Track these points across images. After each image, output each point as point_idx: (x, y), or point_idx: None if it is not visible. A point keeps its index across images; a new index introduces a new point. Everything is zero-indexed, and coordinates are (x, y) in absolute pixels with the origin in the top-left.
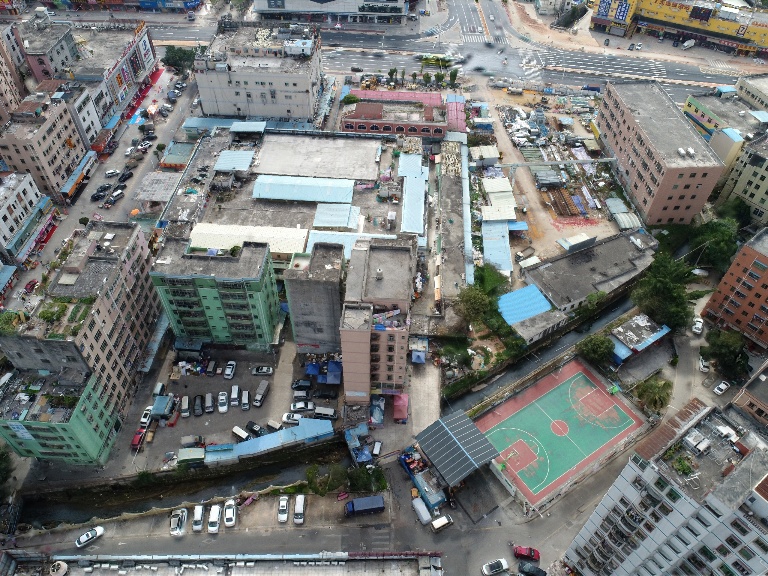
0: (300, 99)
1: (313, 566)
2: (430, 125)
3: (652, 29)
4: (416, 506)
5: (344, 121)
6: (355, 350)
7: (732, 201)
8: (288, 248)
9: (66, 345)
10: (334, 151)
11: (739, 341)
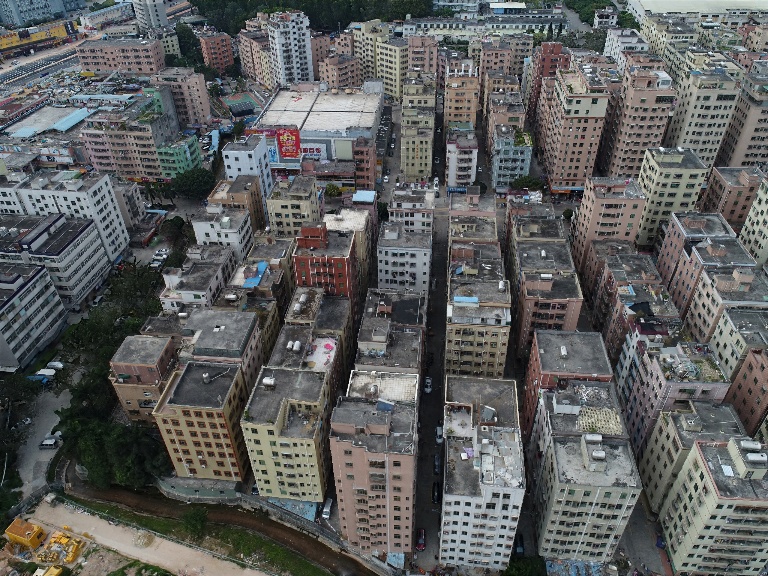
0: None
1: (274, 101)
2: (42, 99)
3: (6, 55)
4: None
5: (8, 118)
6: (202, 88)
7: (165, 59)
8: None
9: (165, 117)
10: None
11: (233, 64)
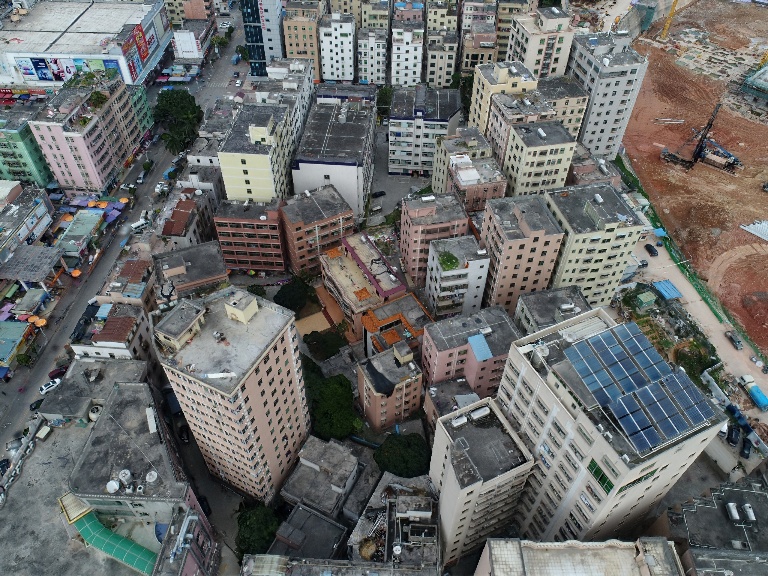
0: None
1: None
2: None
3: None
4: None
5: None
6: None
7: None
8: None
9: None
10: None
11: None
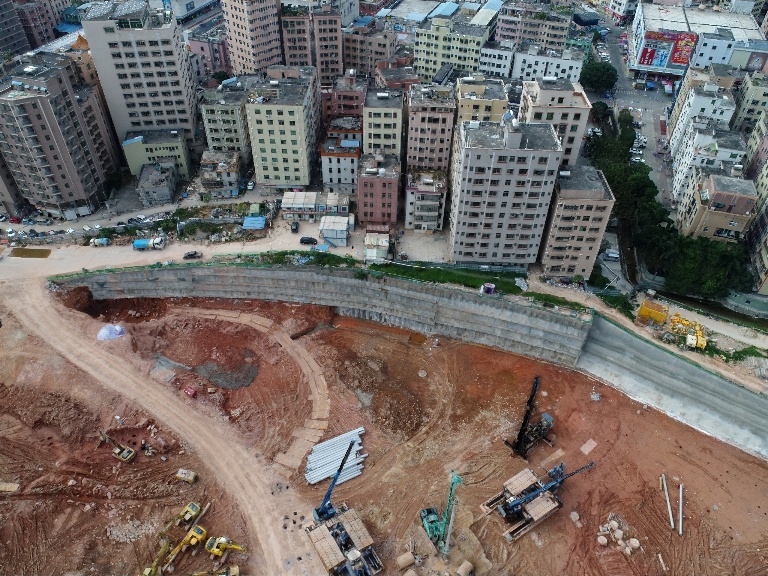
0: (356, 4)
1: None
2: None
3: None
4: (602, 31)
5: (377, 5)
6: None
7: None
8: (493, 12)
9: None
10: (411, 6)
11: None
